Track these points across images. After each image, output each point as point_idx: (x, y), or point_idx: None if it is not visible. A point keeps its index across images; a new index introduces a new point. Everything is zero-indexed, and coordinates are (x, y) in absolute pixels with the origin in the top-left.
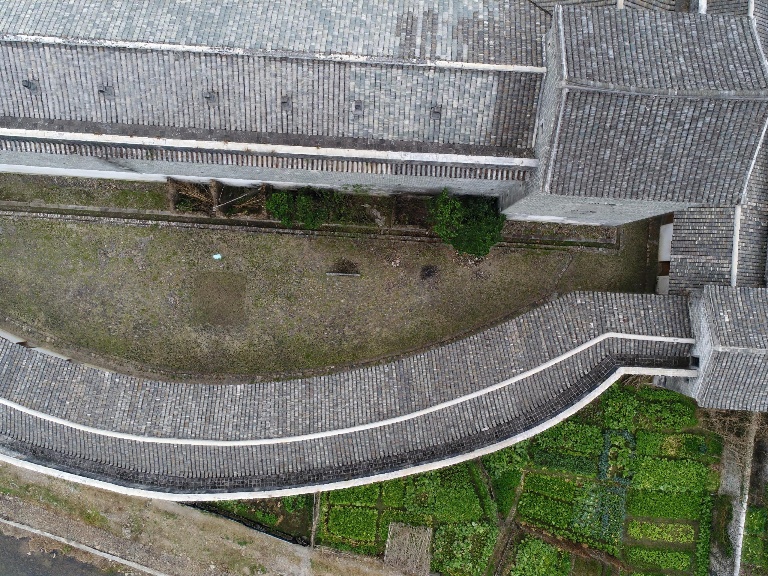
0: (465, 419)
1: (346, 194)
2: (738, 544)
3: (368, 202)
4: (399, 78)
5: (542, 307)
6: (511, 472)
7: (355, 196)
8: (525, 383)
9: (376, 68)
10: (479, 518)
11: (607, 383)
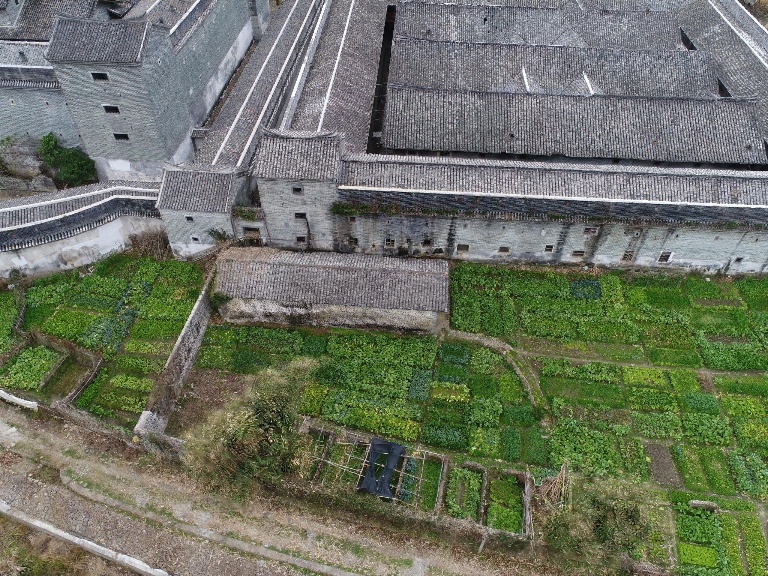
0: (3, 225)
1: (16, 173)
2: (188, 319)
3: (29, 179)
4: (11, 48)
5: (89, 185)
6: (46, 305)
7: (22, 176)
8: (53, 207)
9: (2, 45)
10: (5, 336)
11: (102, 200)
